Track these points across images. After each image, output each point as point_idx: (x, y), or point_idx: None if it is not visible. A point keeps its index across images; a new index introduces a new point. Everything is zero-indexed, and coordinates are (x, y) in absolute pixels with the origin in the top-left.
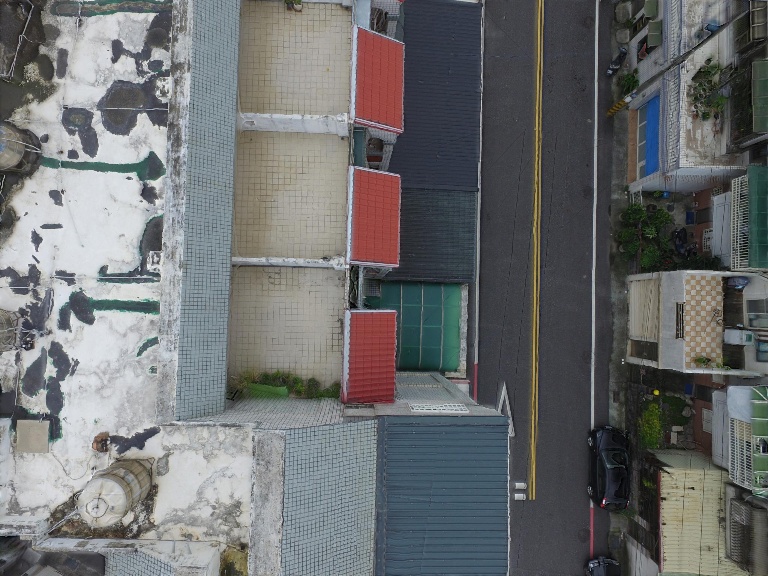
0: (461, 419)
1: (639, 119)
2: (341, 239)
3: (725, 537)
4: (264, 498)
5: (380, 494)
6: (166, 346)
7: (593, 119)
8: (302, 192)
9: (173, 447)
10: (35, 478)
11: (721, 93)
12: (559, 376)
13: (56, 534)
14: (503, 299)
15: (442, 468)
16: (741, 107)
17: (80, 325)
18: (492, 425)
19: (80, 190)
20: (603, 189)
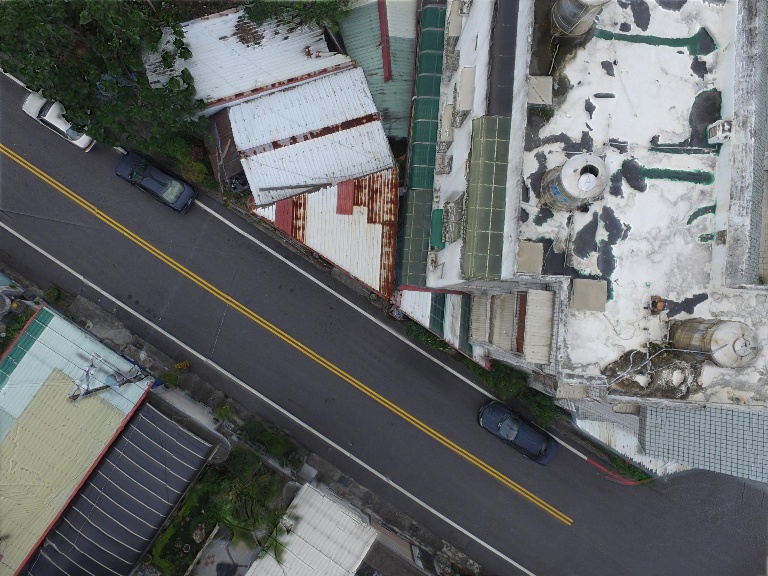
0: None
1: None
2: None
3: None
4: None
5: None
6: (738, 211)
7: None
8: None
9: (719, 314)
10: (586, 336)
11: None
12: None
13: None
14: None
15: None
16: None
17: (631, 192)
18: None
19: (632, 62)
20: None
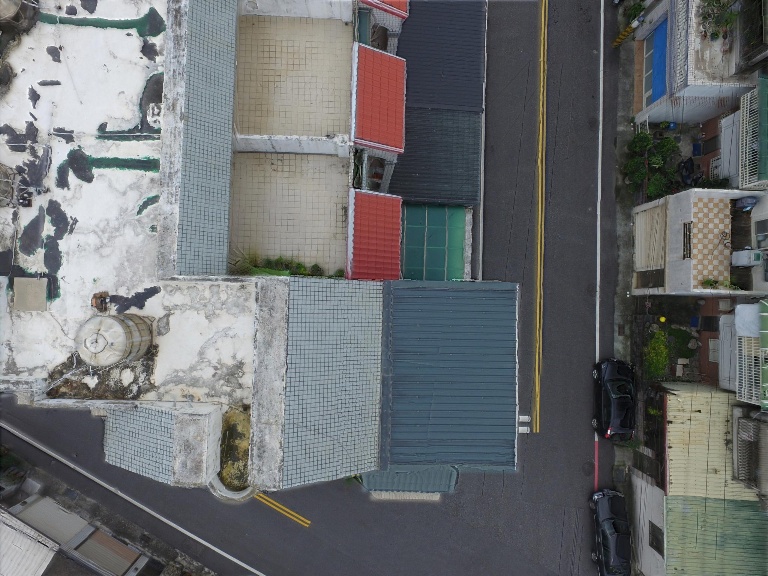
0: (468, 284)
1: (645, 50)
2: (345, 126)
3: (732, 458)
4: (267, 345)
5: (386, 358)
6: (167, 199)
7: (599, 50)
8: (305, 78)
9: (174, 307)
10: (33, 338)
11: (730, 10)
12: (564, 309)
13: (54, 395)
14: (507, 231)
15: (449, 333)
16: (751, 21)
17: (79, 183)
18: (500, 290)
19: (78, 46)
20: (609, 121)
